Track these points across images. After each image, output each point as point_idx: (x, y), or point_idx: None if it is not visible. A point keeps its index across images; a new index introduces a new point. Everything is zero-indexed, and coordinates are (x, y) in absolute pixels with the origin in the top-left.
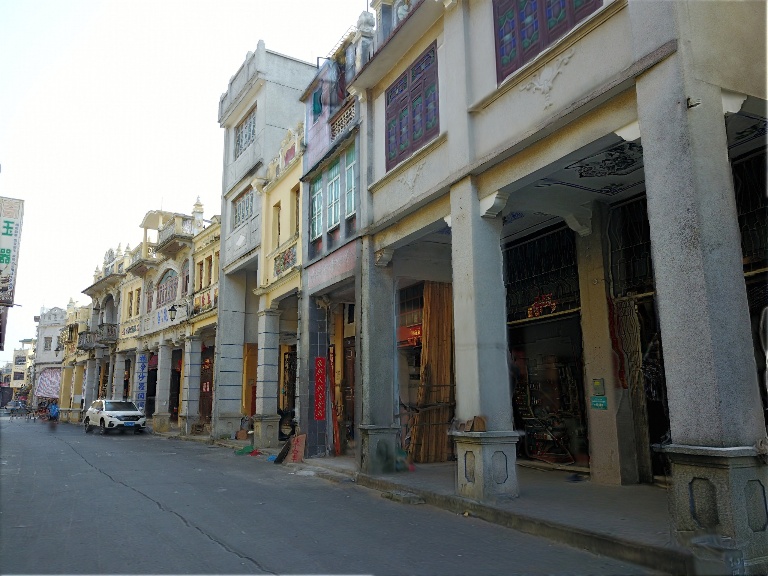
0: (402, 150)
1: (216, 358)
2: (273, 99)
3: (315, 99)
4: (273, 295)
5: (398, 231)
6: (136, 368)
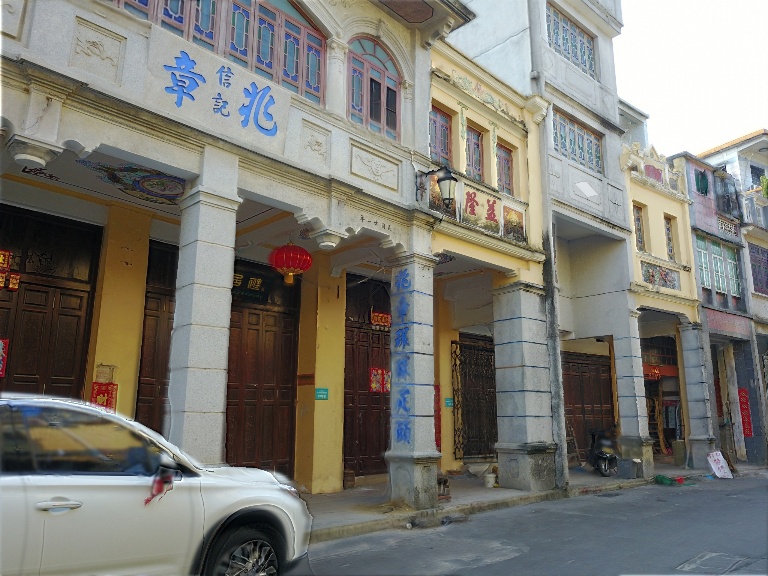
0: (761, 287)
1: None
2: None
3: None
4: (646, 301)
5: (764, 329)
6: None
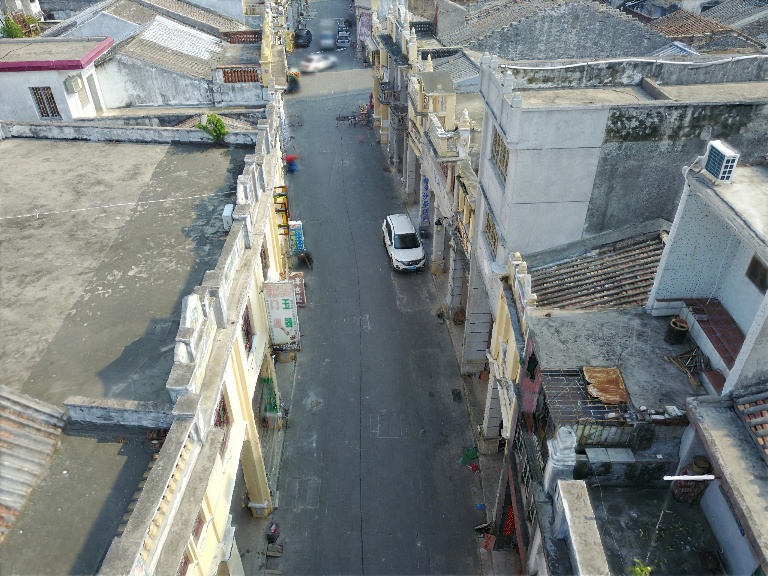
0: None
1: (466, 323)
2: (525, 171)
3: (529, 365)
4: None
5: None
6: (421, 187)
